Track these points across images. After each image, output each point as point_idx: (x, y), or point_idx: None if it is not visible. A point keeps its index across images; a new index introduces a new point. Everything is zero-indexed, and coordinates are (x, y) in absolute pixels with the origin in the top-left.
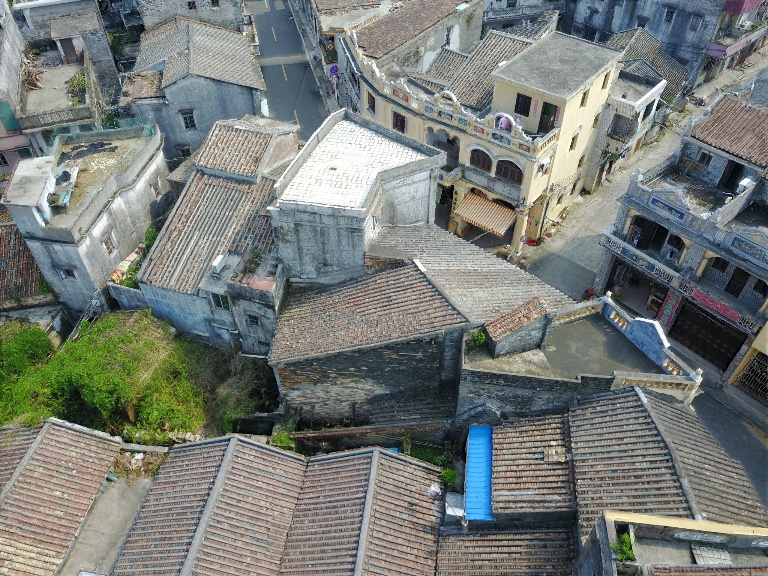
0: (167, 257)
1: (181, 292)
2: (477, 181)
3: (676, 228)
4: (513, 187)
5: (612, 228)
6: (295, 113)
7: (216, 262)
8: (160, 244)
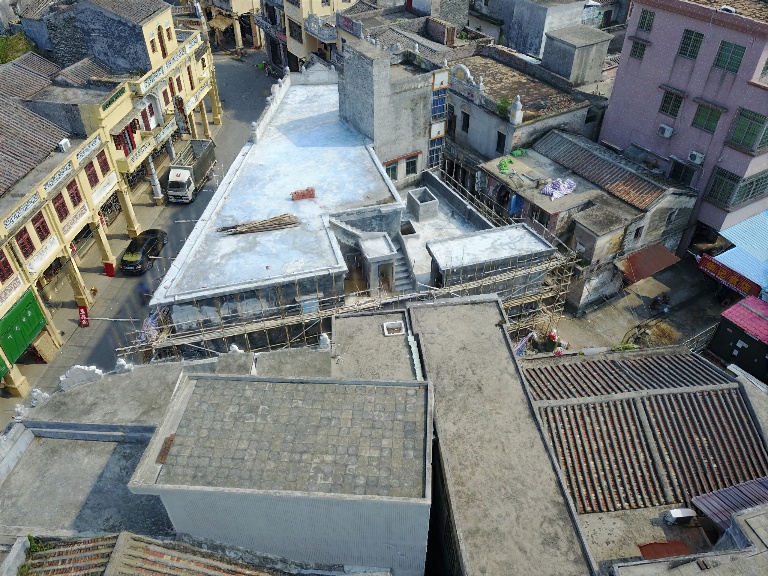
0: (35, 8)
1: (36, 19)
2: (218, 4)
3: (270, 1)
4: (227, 2)
5: (259, 14)
6: (174, 3)
7: (50, 3)
8: (33, 3)
